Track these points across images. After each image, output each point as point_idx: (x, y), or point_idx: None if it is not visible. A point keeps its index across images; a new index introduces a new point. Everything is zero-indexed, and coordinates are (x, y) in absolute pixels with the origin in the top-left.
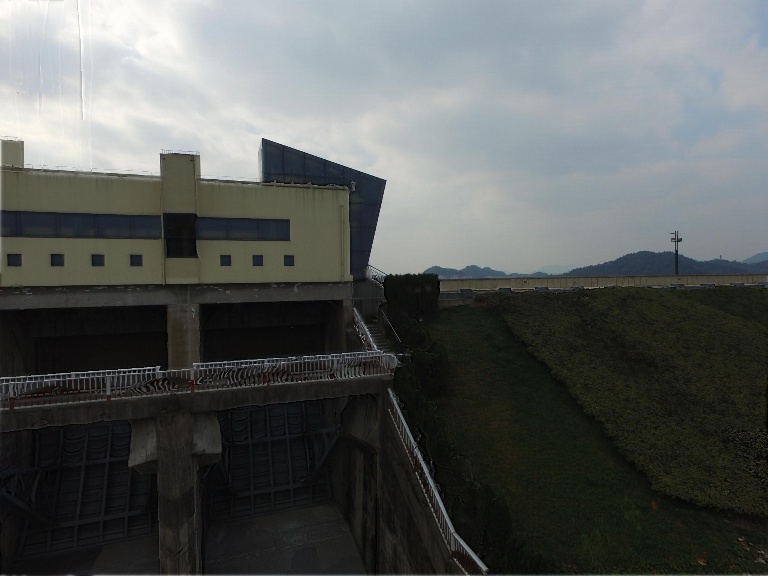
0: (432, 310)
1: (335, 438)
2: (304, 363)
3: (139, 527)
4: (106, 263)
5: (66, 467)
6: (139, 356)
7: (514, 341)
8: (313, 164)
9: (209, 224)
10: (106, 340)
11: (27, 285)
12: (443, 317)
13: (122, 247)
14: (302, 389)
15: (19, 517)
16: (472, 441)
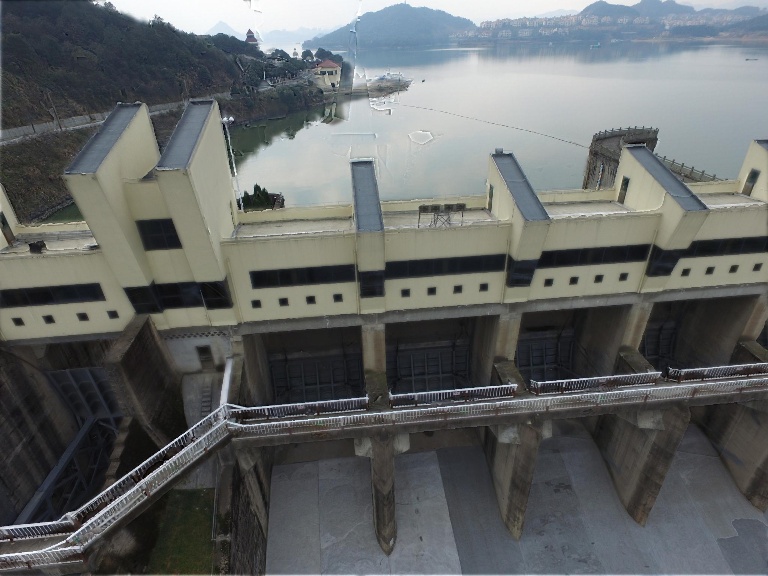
0: None
1: None
2: None
3: None
4: (738, 270)
5: None
6: None
7: None
8: None
9: None
10: None
11: (686, 287)
12: None
13: (752, 259)
14: None
15: None
16: None
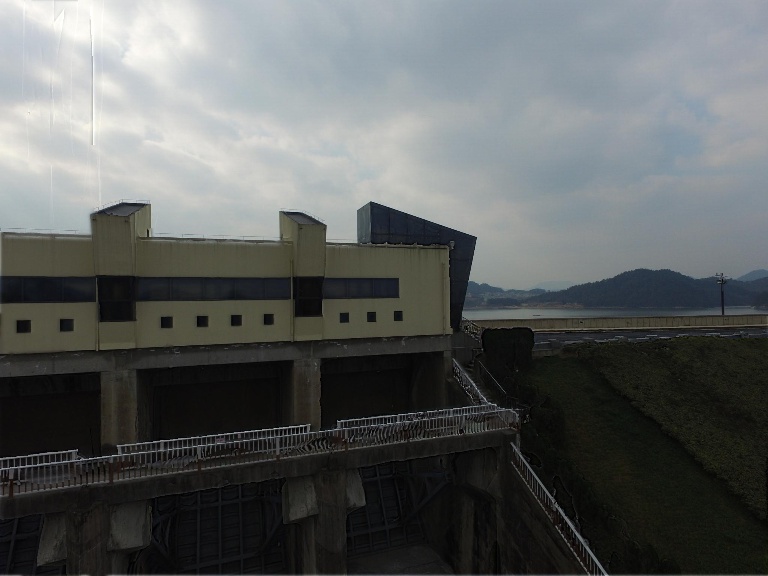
0: (527, 361)
1: (442, 484)
2: (438, 420)
3: (253, 569)
4: (243, 323)
5: (183, 511)
6: (236, 400)
7: (615, 394)
8: (414, 224)
9: (330, 284)
10: (214, 387)
11: (177, 345)
12: (538, 368)
13: (257, 307)
14: (437, 444)
15: (153, 562)
16: (600, 495)
